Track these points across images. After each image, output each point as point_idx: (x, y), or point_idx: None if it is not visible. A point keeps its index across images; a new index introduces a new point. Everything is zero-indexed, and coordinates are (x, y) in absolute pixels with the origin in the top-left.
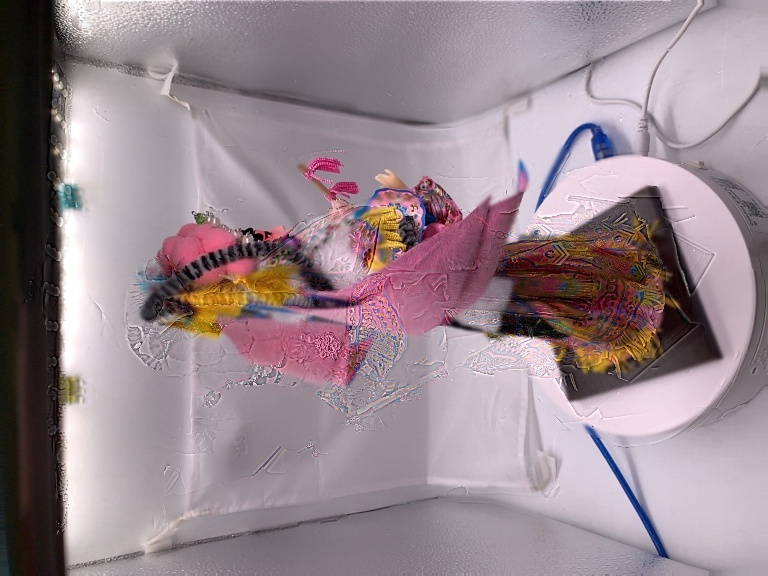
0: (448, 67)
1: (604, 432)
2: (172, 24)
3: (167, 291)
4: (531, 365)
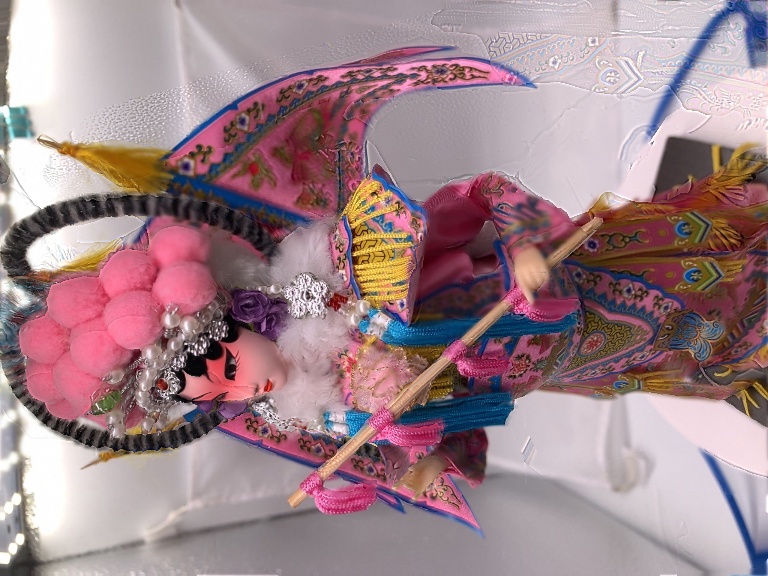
0: (454, 114)
1: None
2: (146, 138)
3: (3, 210)
4: (682, 347)
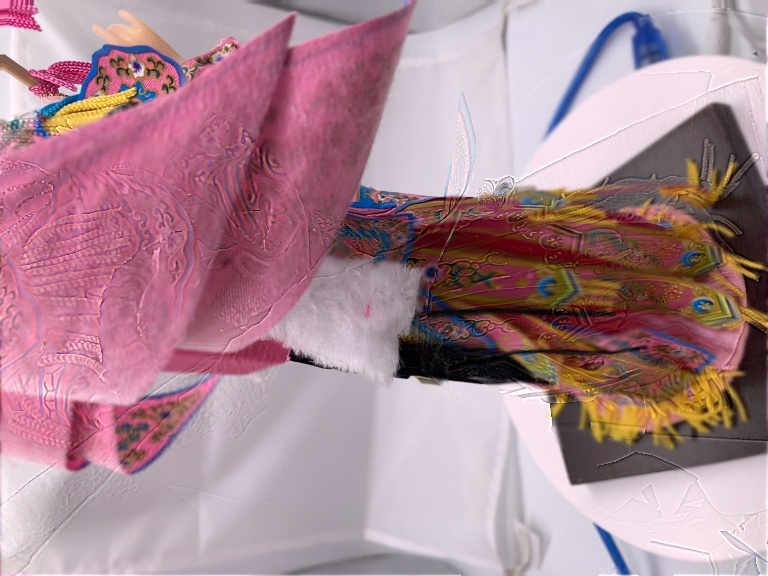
0: None
1: (728, 41)
2: None
3: None
4: (503, 203)
